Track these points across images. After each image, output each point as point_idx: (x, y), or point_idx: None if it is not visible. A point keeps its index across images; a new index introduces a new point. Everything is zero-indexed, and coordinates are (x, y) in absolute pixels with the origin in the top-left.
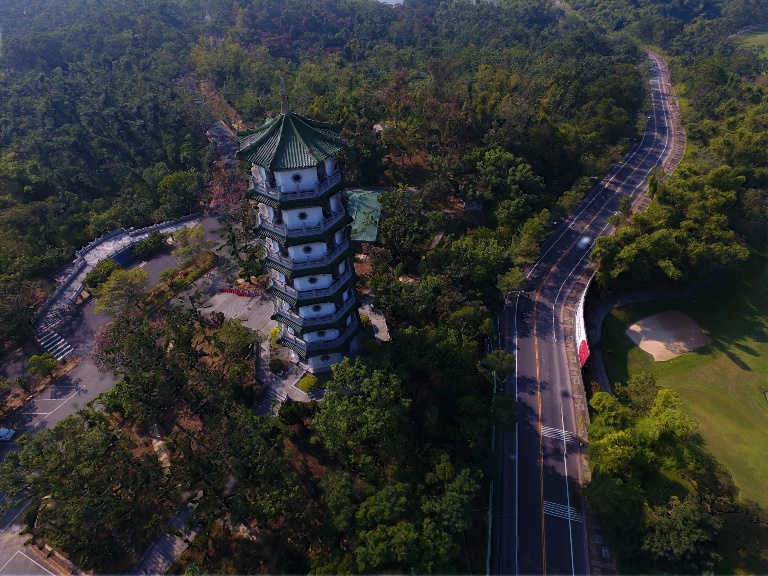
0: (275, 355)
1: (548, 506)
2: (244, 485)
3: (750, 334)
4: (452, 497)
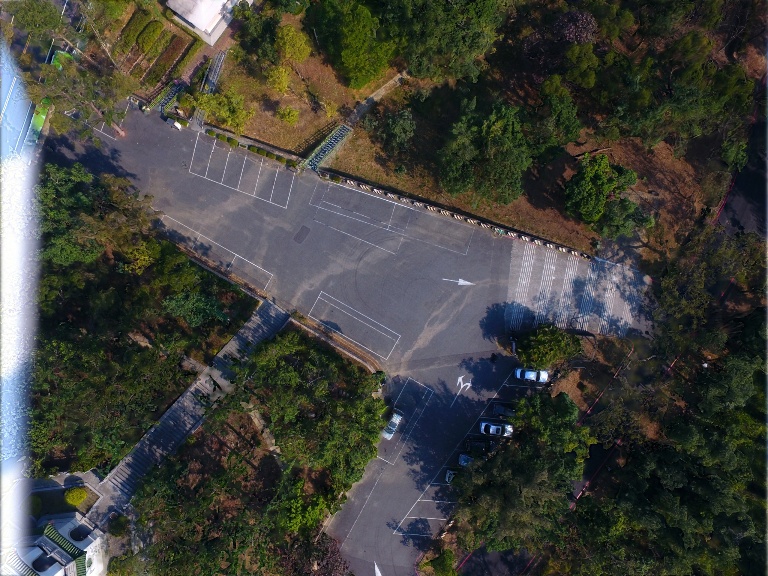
0: (125, 544)
1: None
2: None
3: None
4: None
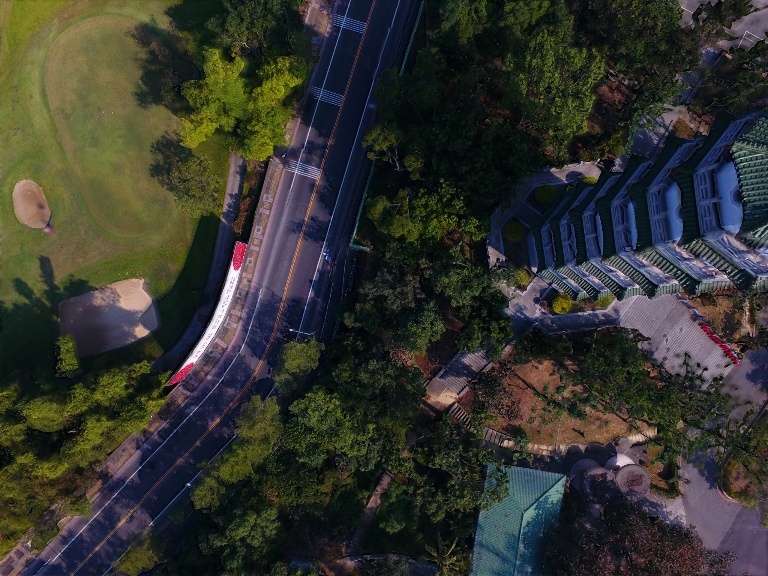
0: None
1: (338, 101)
2: (651, 55)
3: (3, 314)
4: (462, 6)
